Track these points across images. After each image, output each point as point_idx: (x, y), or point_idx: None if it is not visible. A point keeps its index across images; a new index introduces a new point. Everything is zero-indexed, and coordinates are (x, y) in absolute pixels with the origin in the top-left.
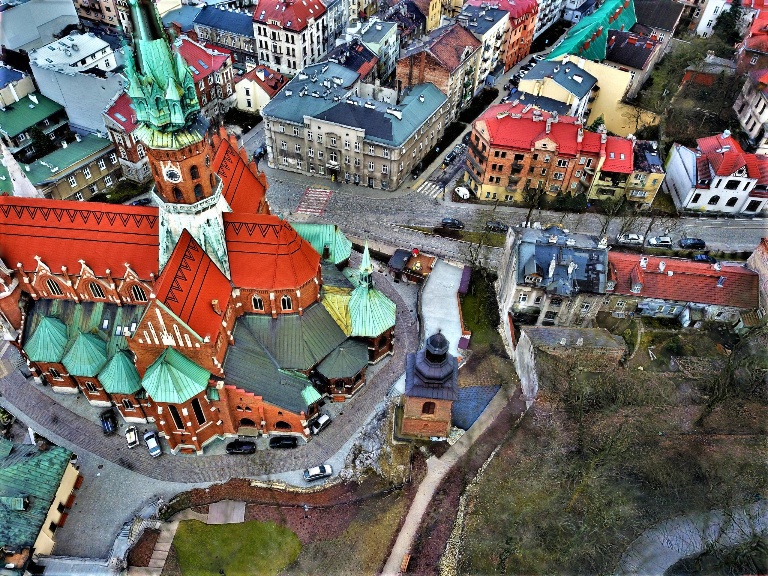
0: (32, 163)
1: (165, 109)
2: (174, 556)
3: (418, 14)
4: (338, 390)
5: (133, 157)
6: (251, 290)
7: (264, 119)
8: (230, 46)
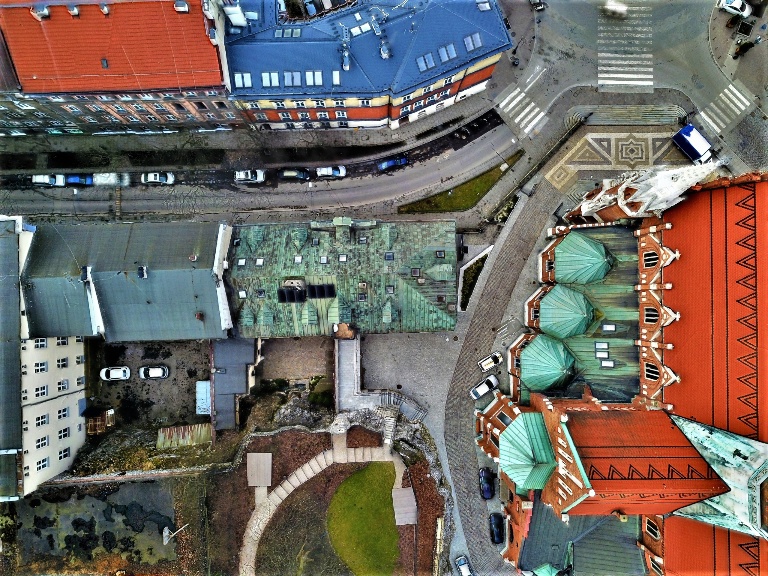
0: None
1: None
2: (359, 468)
3: None
4: None
5: None
6: None
7: None
8: None
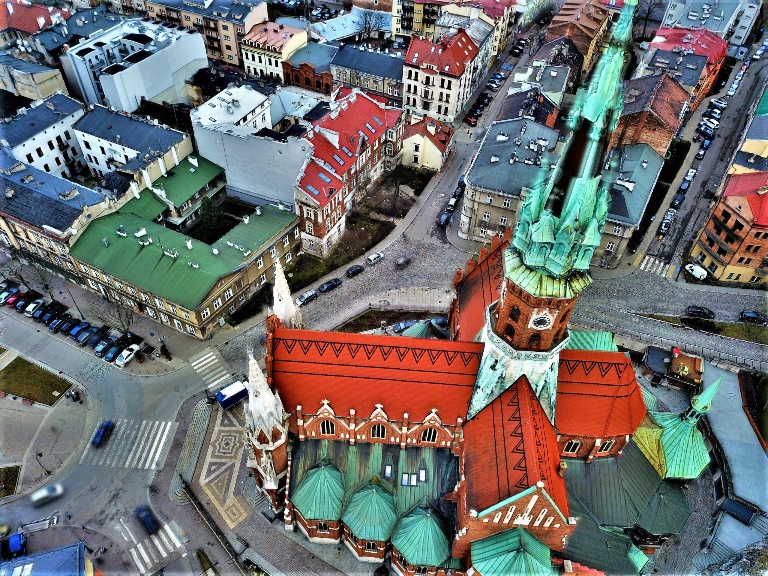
0: (215, 243)
1: (573, 255)
2: None
3: (577, 53)
4: (650, 541)
5: (321, 232)
6: (574, 435)
7: (469, 189)
8: (371, 89)
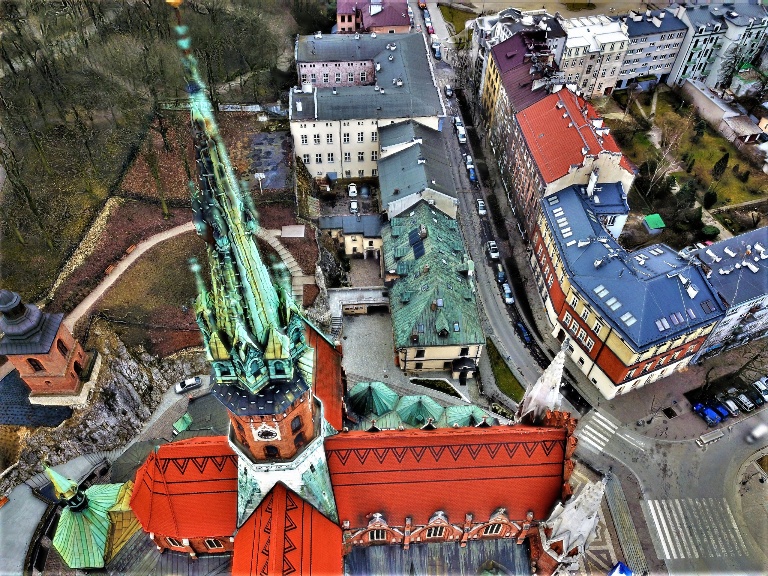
0: None
1: None
2: None
3: None
4: None
5: None
6: None
7: None
8: None
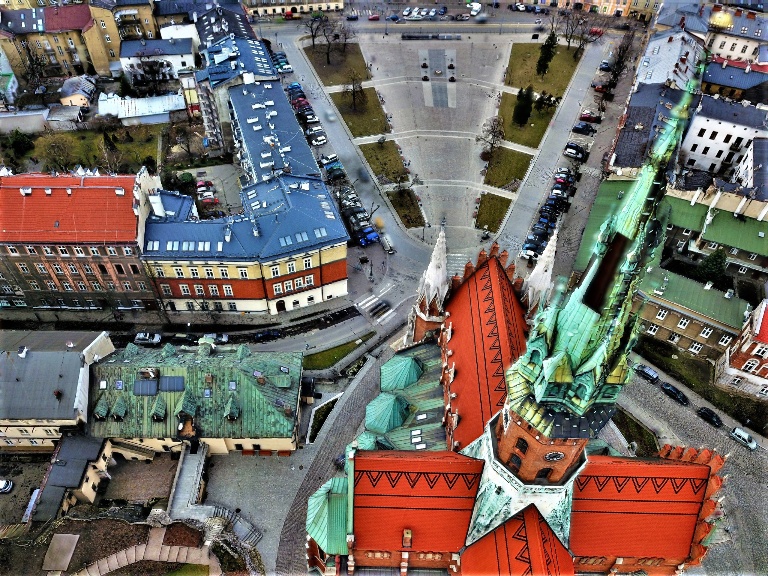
0: (664, 269)
1: (538, 368)
2: (170, 569)
3: None
4: None
5: (735, 360)
6: None
7: None
8: None
